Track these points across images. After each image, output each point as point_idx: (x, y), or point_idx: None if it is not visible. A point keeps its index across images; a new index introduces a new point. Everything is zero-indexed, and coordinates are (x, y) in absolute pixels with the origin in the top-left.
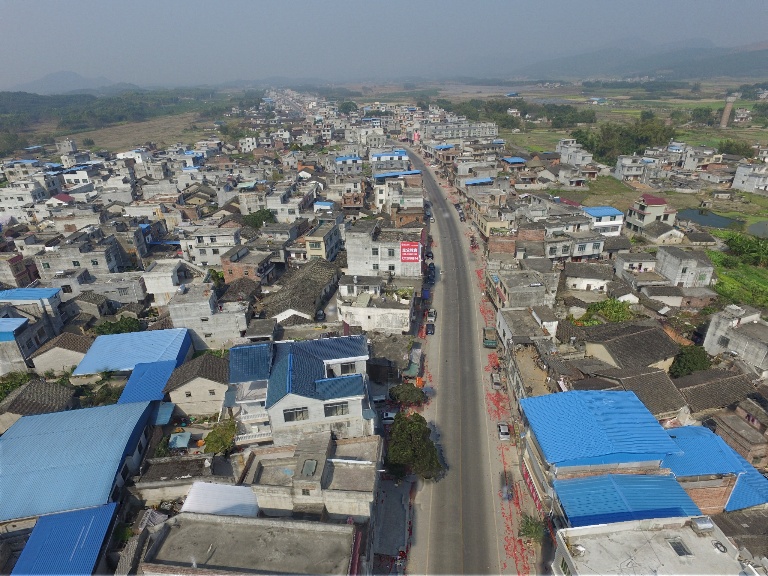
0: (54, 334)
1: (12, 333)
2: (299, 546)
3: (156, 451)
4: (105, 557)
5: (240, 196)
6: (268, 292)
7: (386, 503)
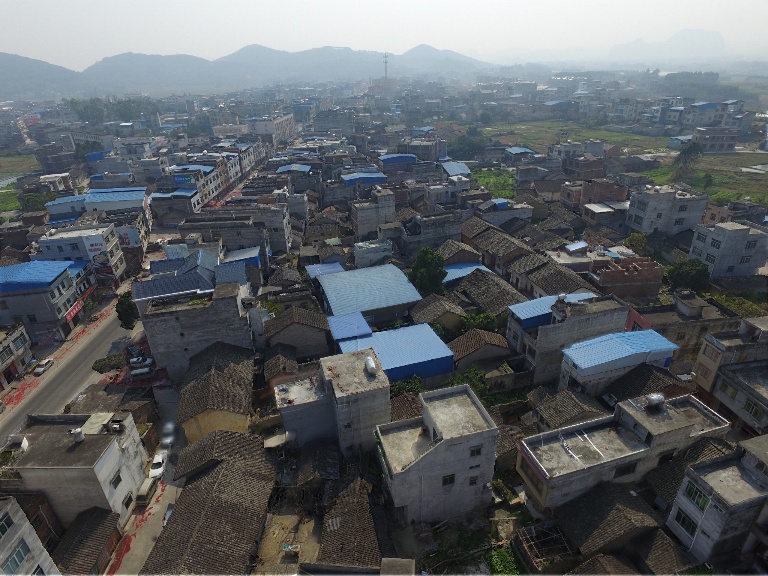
0: None
1: None
2: None
3: (312, 305)
4: None
5: None
6: None
7: None
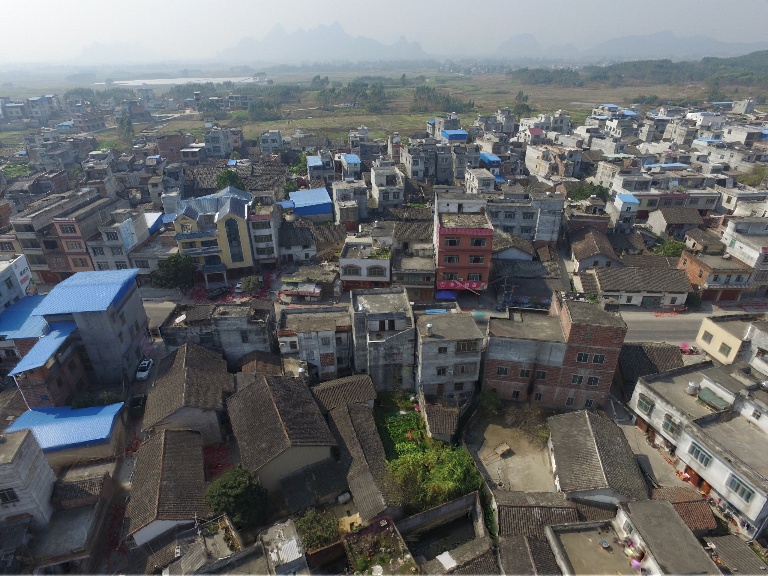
0: None
1: (309, 167)
2: None
3: None
4: None
5: (600, 165)
6: None
7: (168, 290)
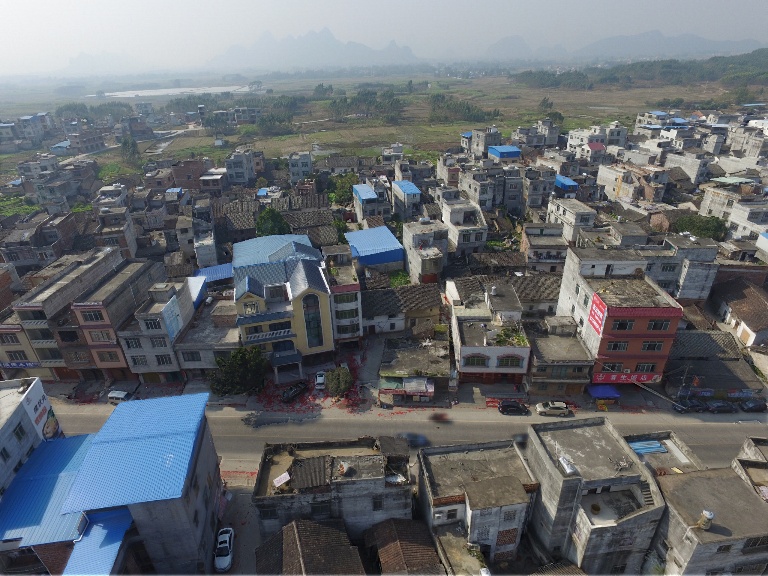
0: (405, 219)
1: (362, 200)
2: (110, 292)
3: None
4: (212, 289)
5: (708, 191)
6: (519, 275)
7: None
